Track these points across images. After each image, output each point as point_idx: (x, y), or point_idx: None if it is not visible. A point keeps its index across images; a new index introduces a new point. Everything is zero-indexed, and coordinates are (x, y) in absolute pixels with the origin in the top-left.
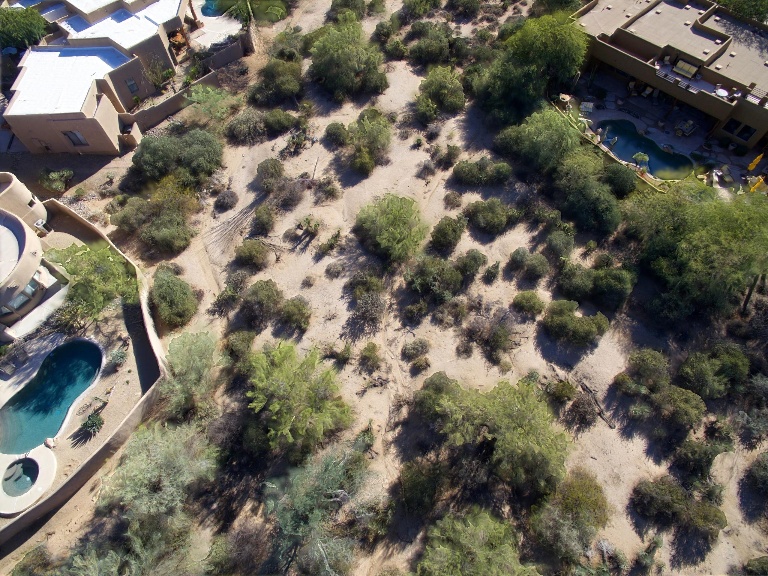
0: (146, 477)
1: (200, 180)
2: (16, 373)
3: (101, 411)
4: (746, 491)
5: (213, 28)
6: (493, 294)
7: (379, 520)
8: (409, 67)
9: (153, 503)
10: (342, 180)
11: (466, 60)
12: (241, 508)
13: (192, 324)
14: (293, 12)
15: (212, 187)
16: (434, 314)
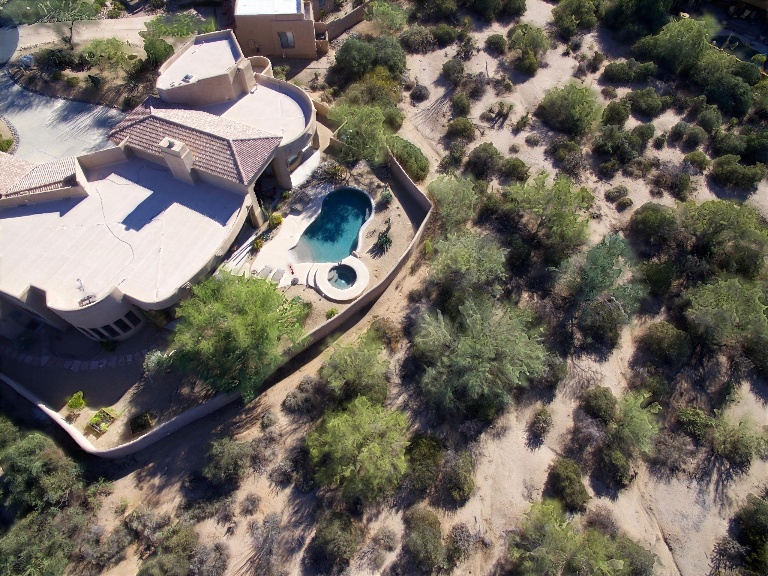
0: (472, 256)
1: (396, 76)
2: (304, 210)
3: (386, 234)
4: None
5: None
6: (665, 156)
7: (632, 298)
8: None
9: (482, 273)
10: (512, 79)
11: None
12: (520, 296)
13: (428, 180)
14: None
15: (404, 84)
16: (625, 169)
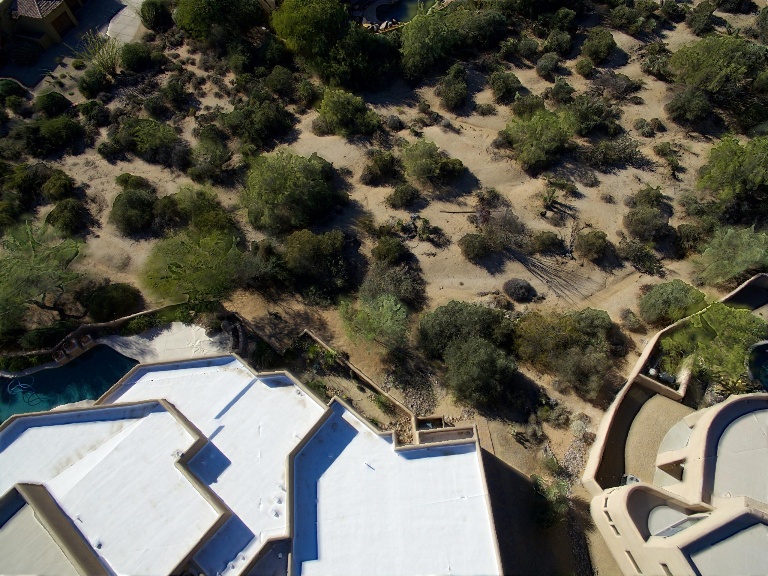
0: None
1: None
2: None
3: None
4: (676, 1)
5: None
6: (581, 87)
7: None
8: (281, 147)
9: None
10: (470, 191)
11: None
12: None
13: None
14: None
15: None
16: None
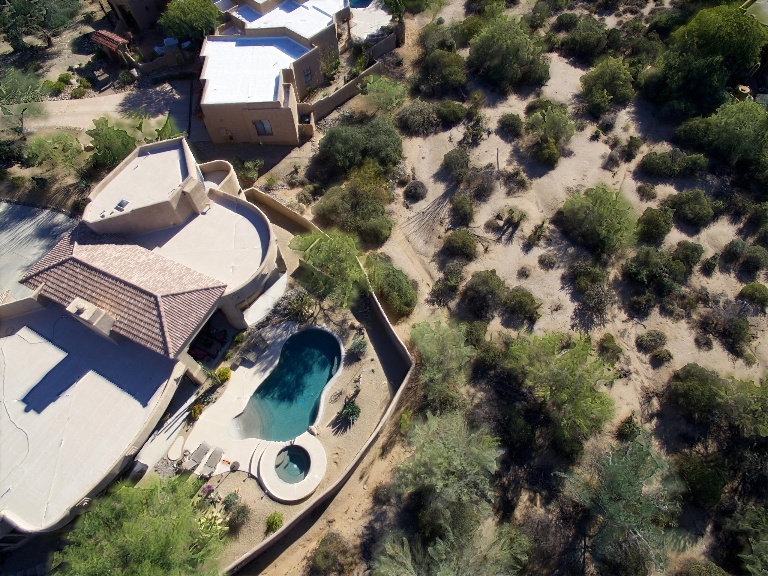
0: (452, 465)
1: (388, 170)
2: (258, 361)
3: (354, 399)
4: None
5: (362, 19)
6: (716, 286)
7: (668, 512)
8: (564, 59)
9: (464, 491)
10: (527, 171)
11: (619, 52)
12: (518, 498)
13: (415, 314)
14: (430, 4)
15: (397, 177)
16: (663, 306)
